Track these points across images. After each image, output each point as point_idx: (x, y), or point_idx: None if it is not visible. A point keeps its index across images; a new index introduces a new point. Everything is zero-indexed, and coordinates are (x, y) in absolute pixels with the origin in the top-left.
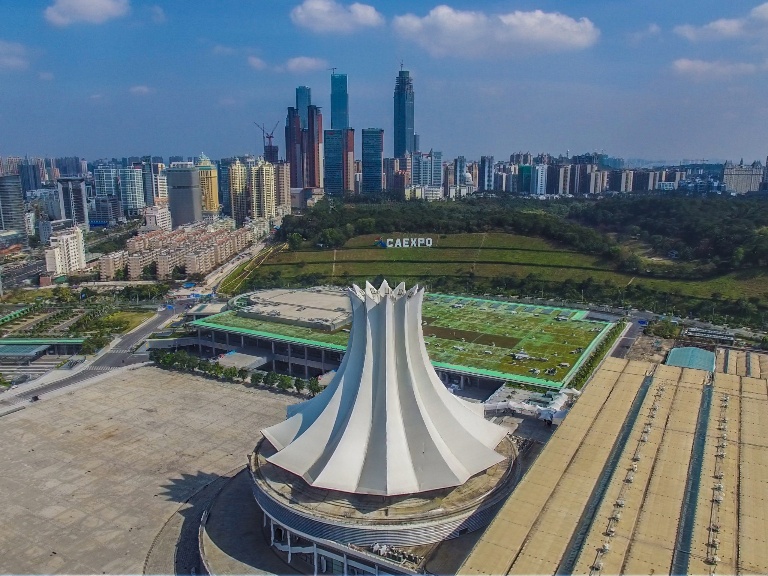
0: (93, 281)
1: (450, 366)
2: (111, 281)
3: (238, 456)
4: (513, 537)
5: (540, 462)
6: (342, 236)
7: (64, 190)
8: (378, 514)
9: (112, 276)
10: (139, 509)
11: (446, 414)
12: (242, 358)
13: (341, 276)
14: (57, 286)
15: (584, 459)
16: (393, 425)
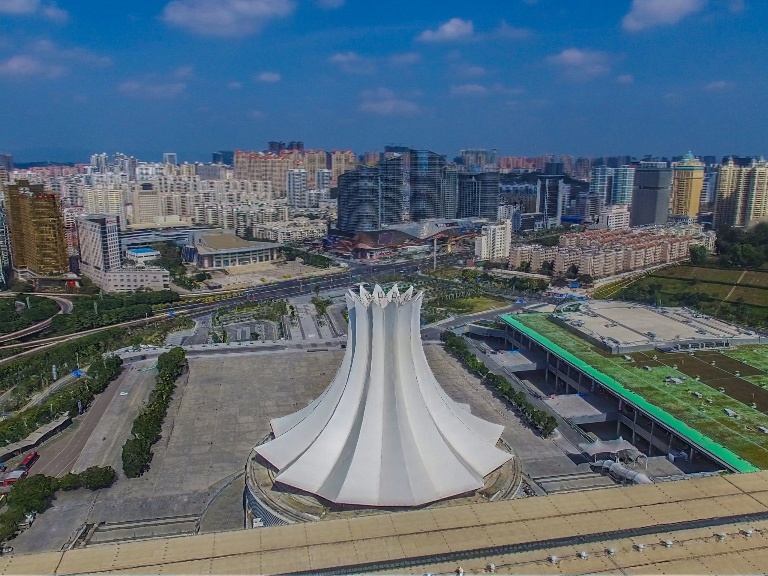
0: (502, 268)
1: (681, 427)
2: (515, 271)
3: None
4: (235, 546)
5: (398, 515)
6: (759, 255)
7: (542, 186)
8: (277, 495)
9: (517, 266)
10: None
11: (397, 436)
12: (516, 359)
13: (733, 302)
14: (475, 268)
15: (443, 537)
16: (338, 425)
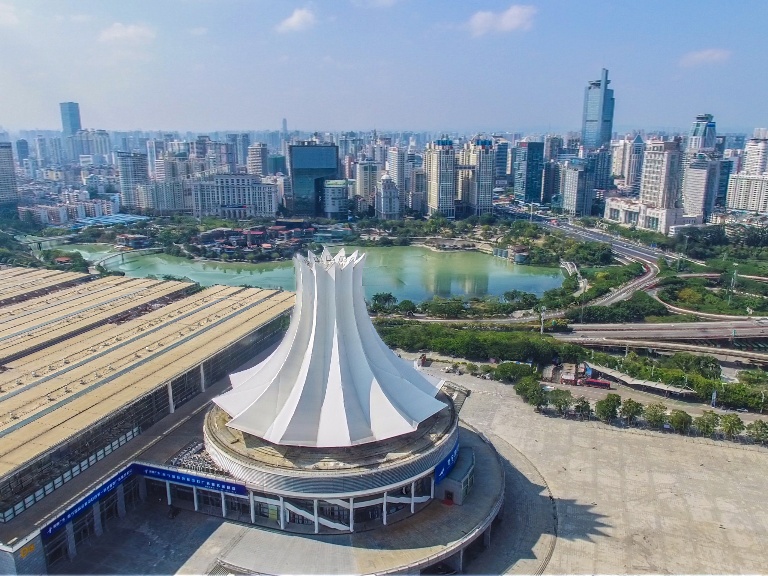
0: None
1: None
2: None
3: (577, 575)
4: (251, 322)
5: None
6: None
7: None
8: None
9: None
10: (588, 488)
11: None
12: None
13: None
14: None
15: (178, 355)
16: None
